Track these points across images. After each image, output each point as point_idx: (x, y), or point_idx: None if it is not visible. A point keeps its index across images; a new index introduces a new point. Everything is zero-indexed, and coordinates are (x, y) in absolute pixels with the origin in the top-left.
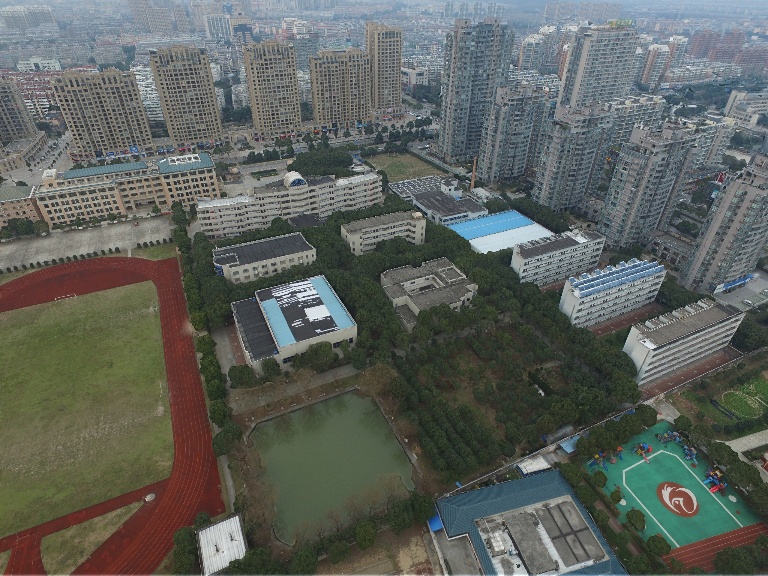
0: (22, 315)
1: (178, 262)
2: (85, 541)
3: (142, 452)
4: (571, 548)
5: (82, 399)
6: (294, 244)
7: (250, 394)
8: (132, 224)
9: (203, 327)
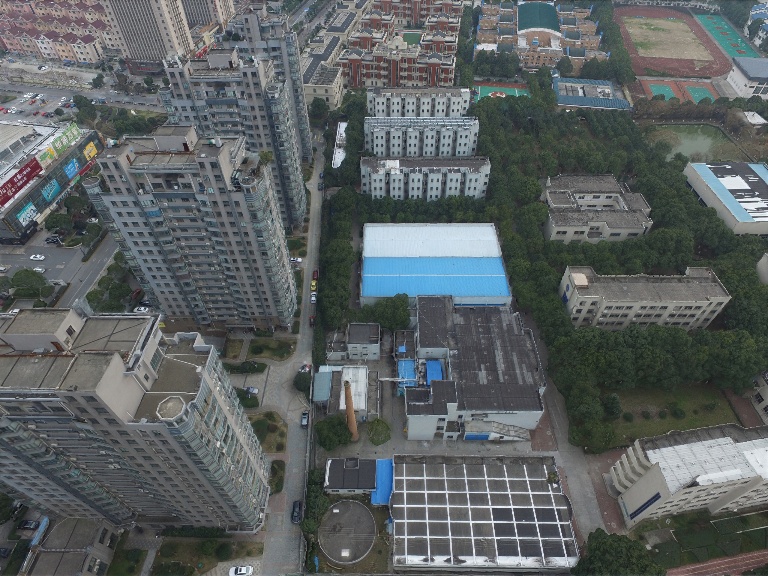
0: None
1: None
2: None
3: None
4: (572, 88)
5: None
6: None
7: None
8: None
9: None
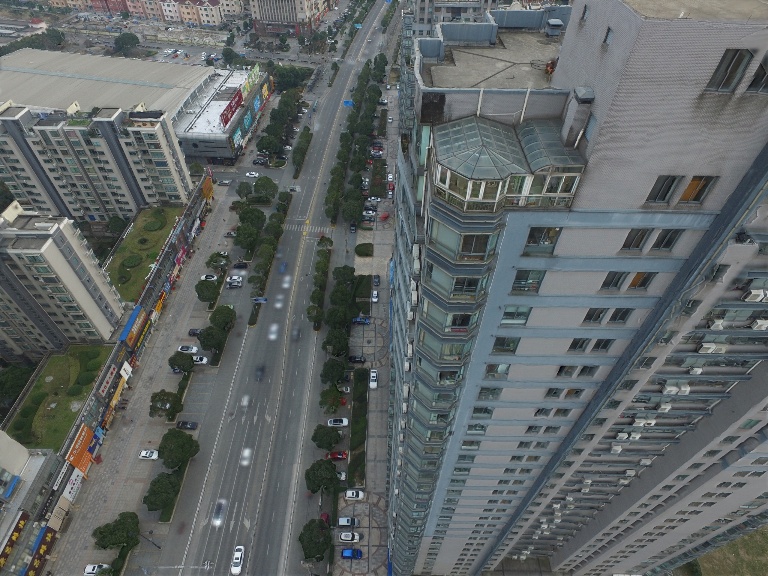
0: None
1: None
2: None
3: None
4: None
5: None
6: None
7: None
8: None
9: None
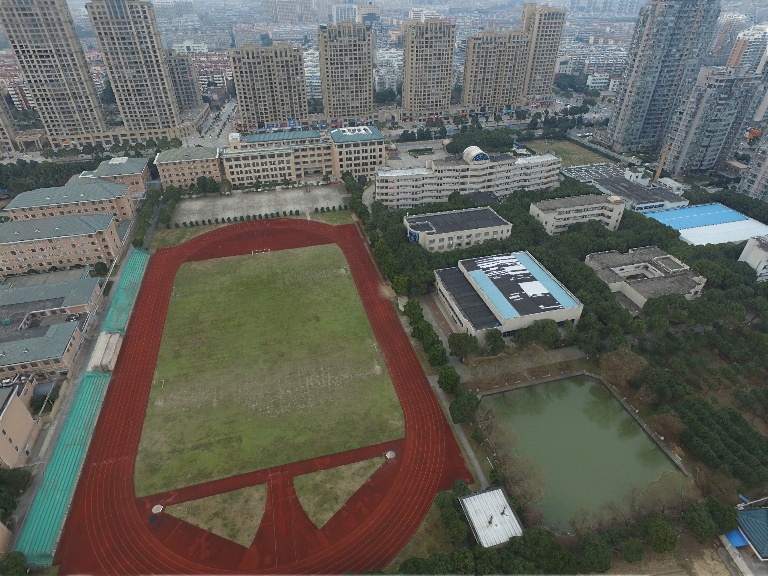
0: (224, 264)
1: (357, 228)
2: (336, 488)
3: (370, 408)
4: None
5: (298, 348)
6: (486, 218)
7: (487, 363)
8: (304, 190)
9: (405, 292)
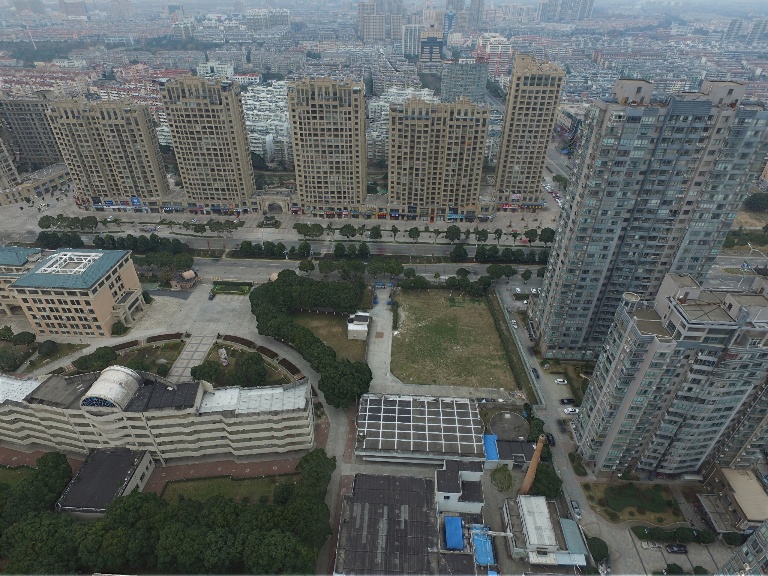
0: None
1: None
2: None
3: None
4: None
5: None
6: None
7: None
8: None
9: None
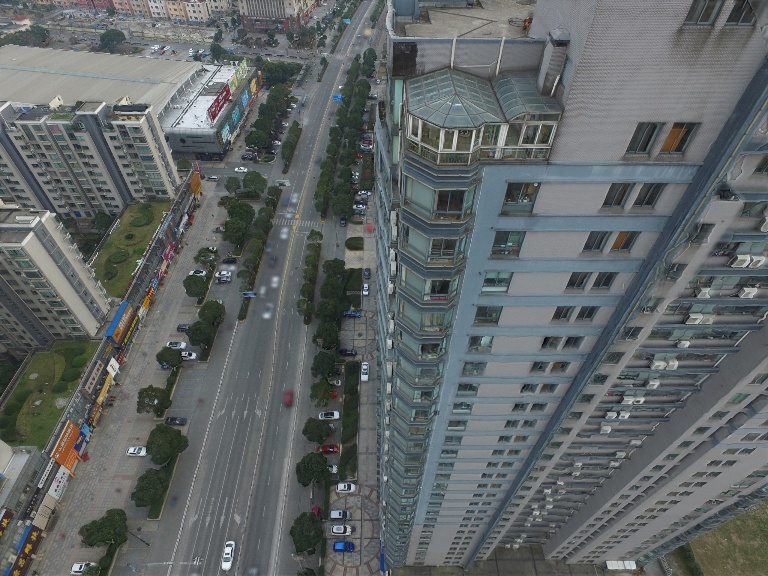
0: None
1: None
2: None
3: None
4: None
5: None
6: None
7: None
8: None
9: None
